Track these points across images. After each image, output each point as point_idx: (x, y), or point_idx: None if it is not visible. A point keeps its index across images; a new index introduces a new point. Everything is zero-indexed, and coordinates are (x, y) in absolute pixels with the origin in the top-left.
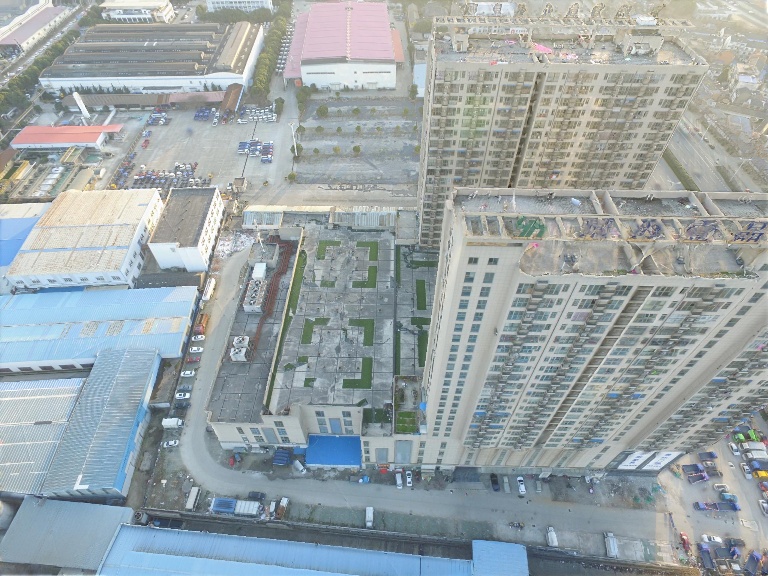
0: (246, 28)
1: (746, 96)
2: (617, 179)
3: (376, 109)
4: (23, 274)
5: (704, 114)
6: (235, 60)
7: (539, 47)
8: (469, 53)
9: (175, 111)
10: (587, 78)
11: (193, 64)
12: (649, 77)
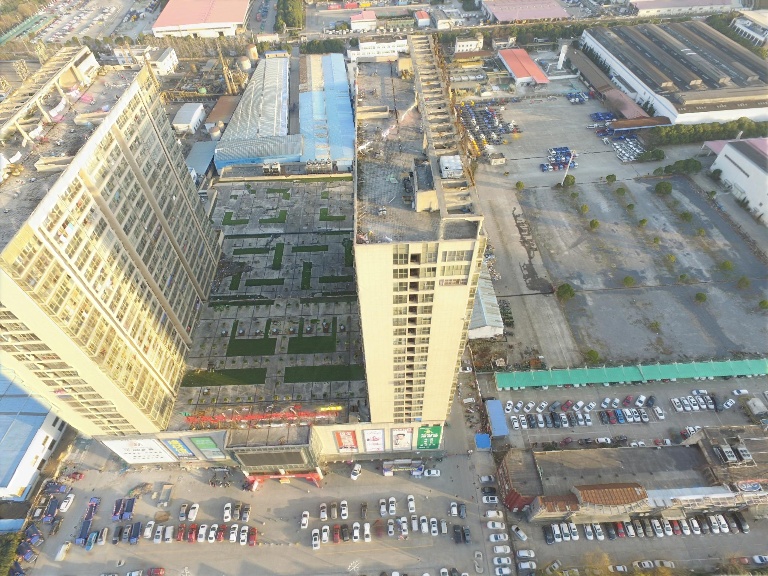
0: None
1: None
2: None
3: (715, 238)
4: None
5: None
6: (706, 102)
7: None
8: (392, 76)
9: (599, 103)
10: None
11: (666, 80)
12: None
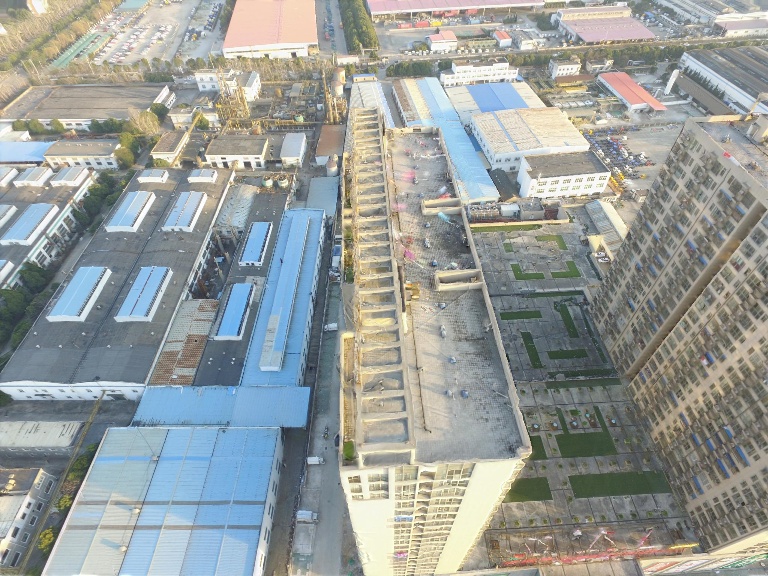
0: None
1: None
2: (764, 457)
3: None
4: (475, 120)
5: None
6: None
7: None
8: (752, 143)
9: None
10: None
11: None
12: None
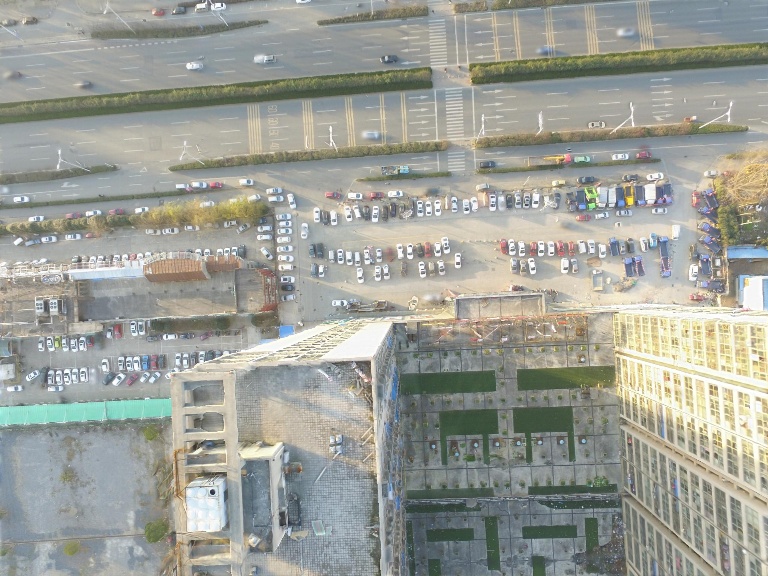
0: None
1: None
2: None
3: None
4: None
5: None
6: None
7: None
8: None
9: None
10: None
11: None
12: None
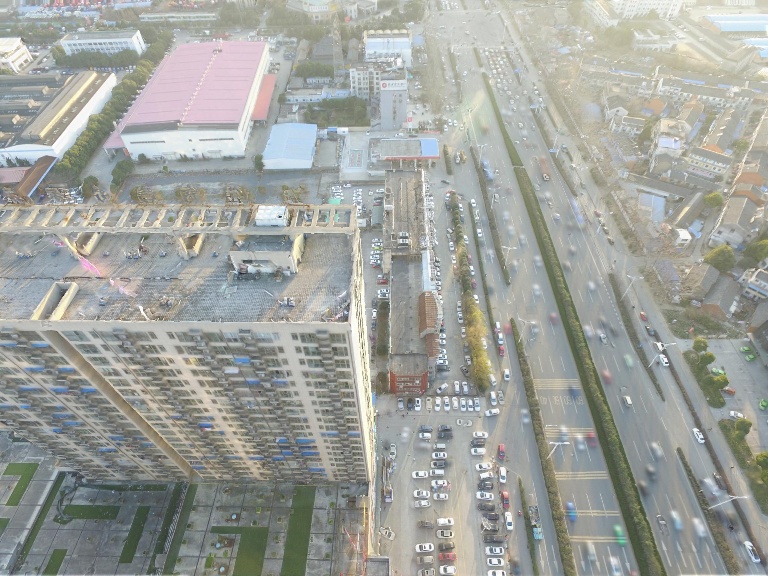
0: (86, 80)
1: (666, 166)
2: (312, 430)
3: (210, 187)
4: None
5: (611, 191)
6: (52, 125)
7: (85, 263)
8: None
9: None
10: (137, 338)
11: None
12: (249, 337)
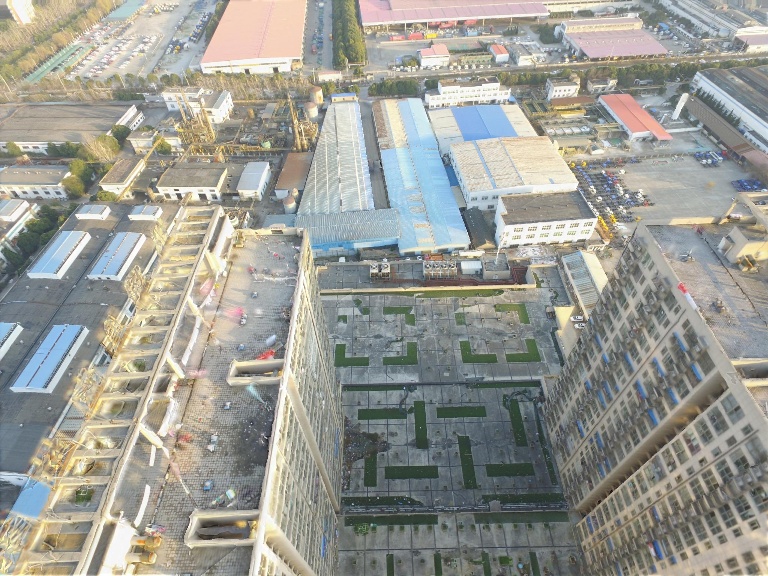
0: None
1: None
2: None
3: None
4: (453, 150)
5: None
6: None
7: None
8: (722, 265)
9: (736, 165)
10: None
11: None
12: None
